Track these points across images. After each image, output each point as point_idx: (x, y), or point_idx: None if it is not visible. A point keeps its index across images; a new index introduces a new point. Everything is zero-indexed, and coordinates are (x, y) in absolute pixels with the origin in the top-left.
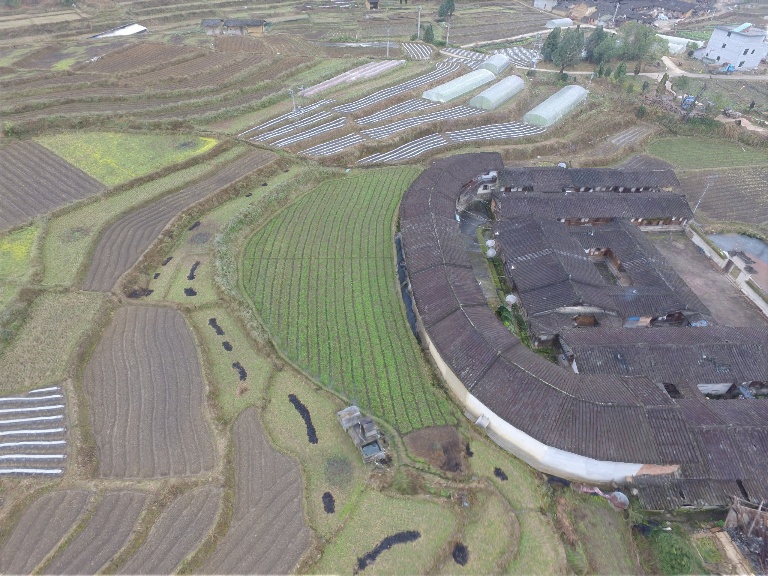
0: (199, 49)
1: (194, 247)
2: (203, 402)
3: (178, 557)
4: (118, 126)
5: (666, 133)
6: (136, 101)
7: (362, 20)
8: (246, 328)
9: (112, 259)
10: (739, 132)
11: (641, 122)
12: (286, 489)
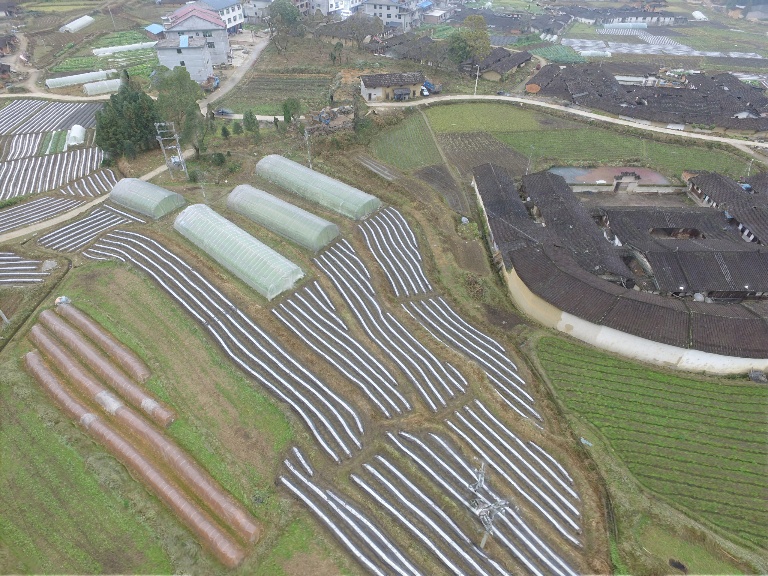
0: None
1: None
2: None
3: None
4: None
5: None
6: None
7: None
8: None
9: None
10: (382, 119)
11: (349, 152)
12: None
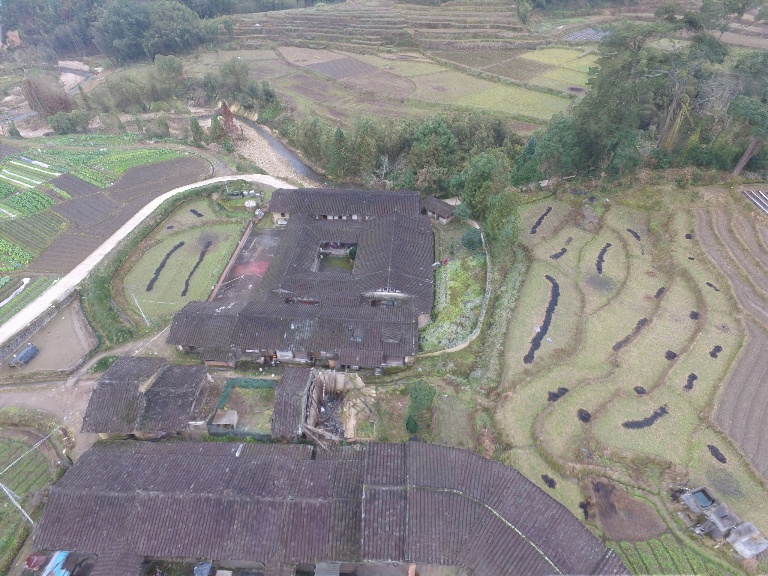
0: None
1: None
2: None
3: None
4: None
5: None
6: None
7: None
8: None
9: None
10: None
11: None
12: (767, 466)
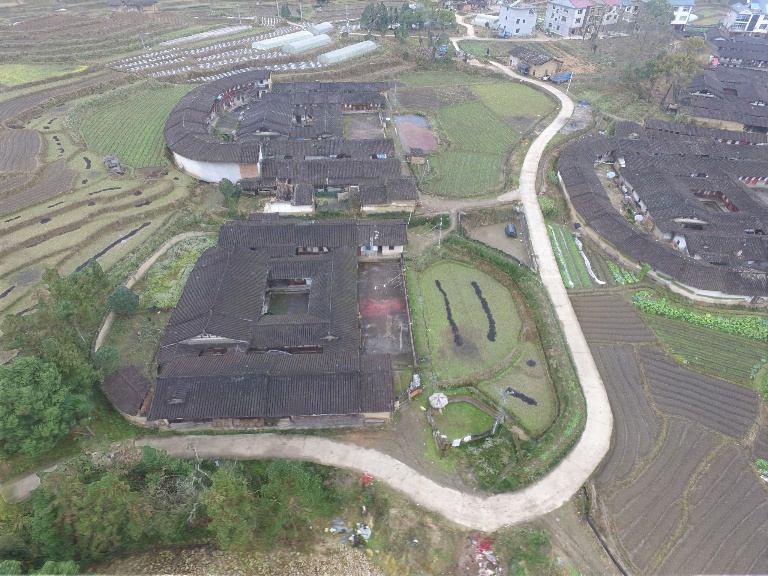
0: (97, 18)
1: (56, 113)
2: (35, 155)
3: (7, 188)
4: (24, 61)
5: (420, 69)
6: (40, 47)
7: (253, 6)
8: (71, 137)
9: (3, 114)
10: (464, 66)
11: (405, 63)
12: None
